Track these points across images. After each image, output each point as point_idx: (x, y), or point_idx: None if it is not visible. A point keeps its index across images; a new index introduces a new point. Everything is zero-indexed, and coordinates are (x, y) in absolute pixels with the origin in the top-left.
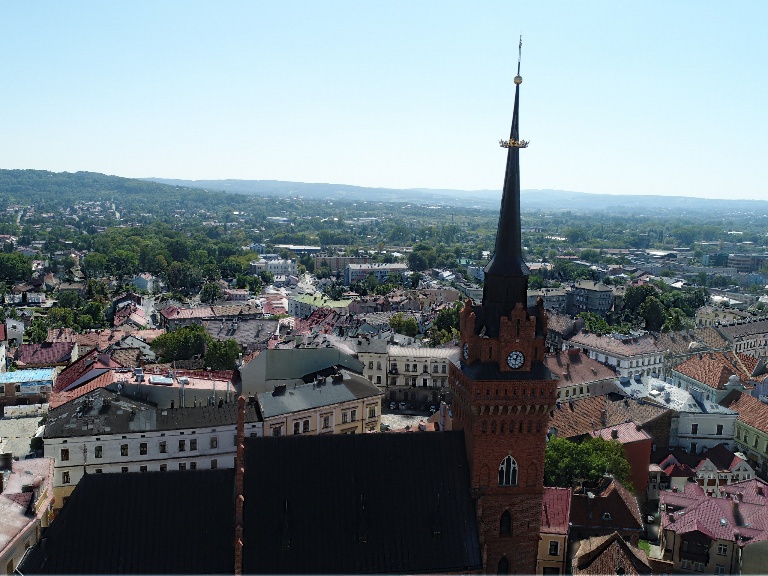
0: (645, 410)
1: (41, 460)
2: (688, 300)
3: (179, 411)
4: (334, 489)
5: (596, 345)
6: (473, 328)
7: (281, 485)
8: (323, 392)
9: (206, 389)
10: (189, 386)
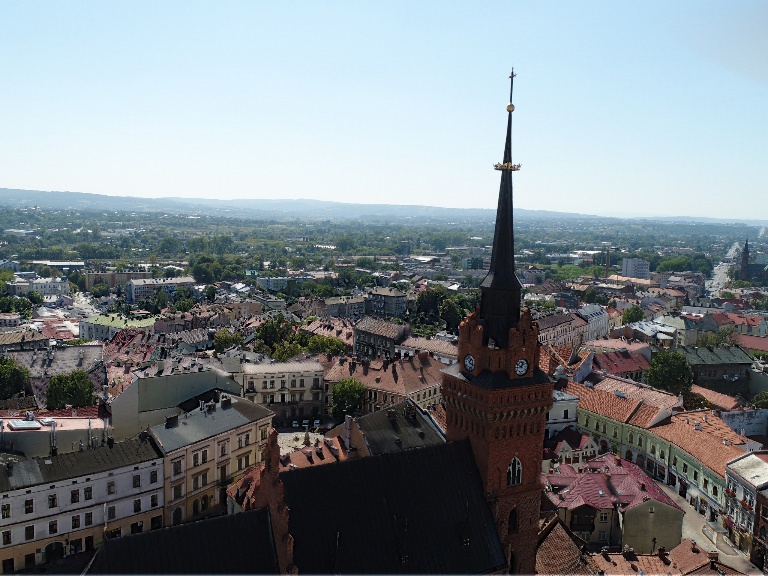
0: None
1: None
2: (471, 301)
3: (65, 457)
4: (369, 513)
5: (428, 348)
6: (481, 340)
7: (320, 518)
8: (216, 418)
9: (80, 429)
10: (58, 428)
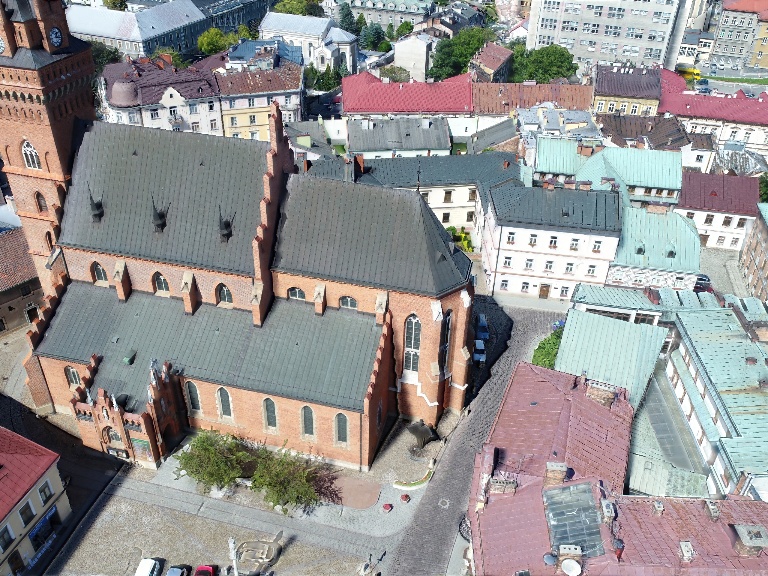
0: None
1: None
2: None
3: None
4: None
5: None
6: None
7: None
8: None
9: None
10: None
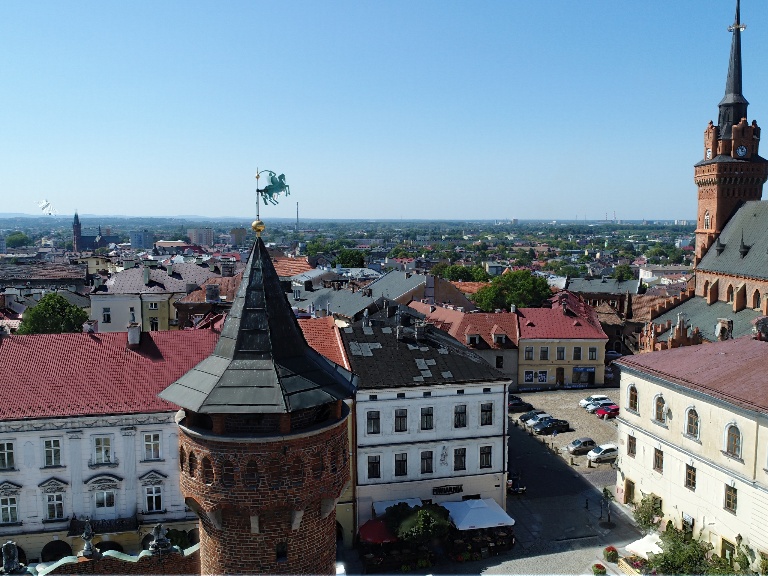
0: None
1: None
2: None
3: None
4: None
5: None
6: None
7: None
8: None
9: None
10: None
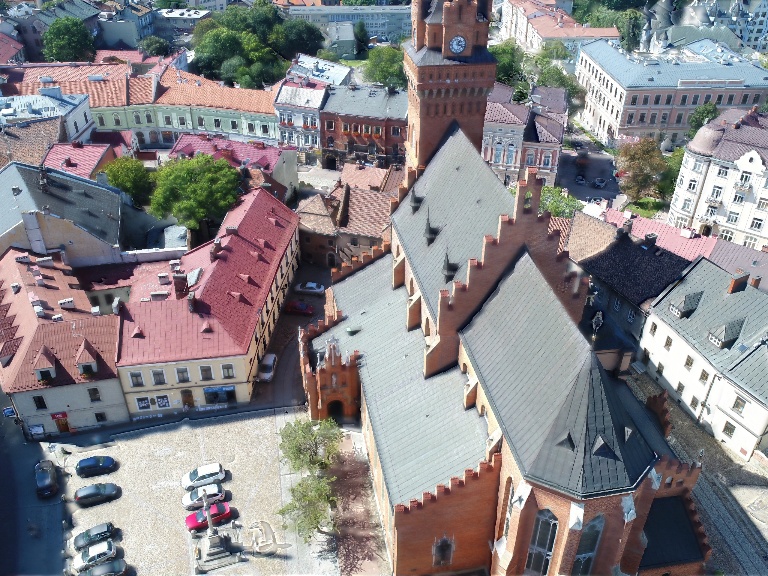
0: (39, 130)
1: None
2: None
3: None
4: None
5: None
6: None
7: None
8: None
9: None
10: None
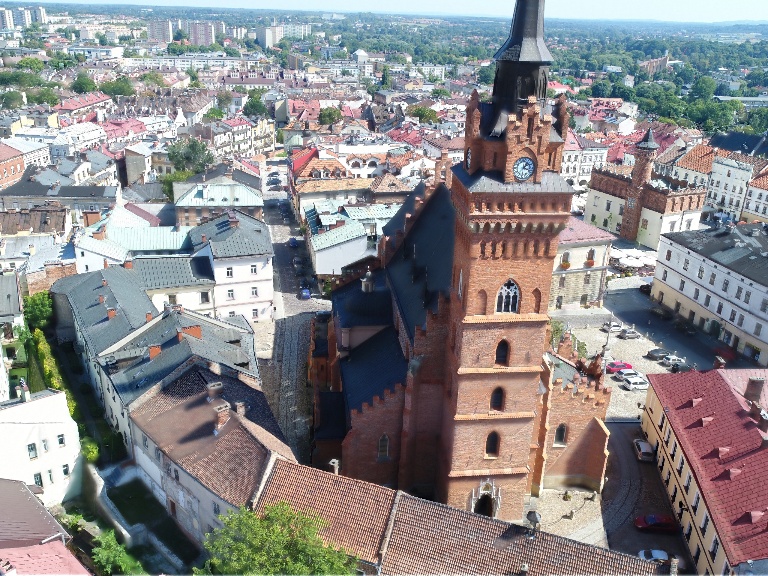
0: None
1: (602, 232)
2: None
3: (766, 262)
4: None
5: None
6: None
7: None
8: None
9: None
10: None
